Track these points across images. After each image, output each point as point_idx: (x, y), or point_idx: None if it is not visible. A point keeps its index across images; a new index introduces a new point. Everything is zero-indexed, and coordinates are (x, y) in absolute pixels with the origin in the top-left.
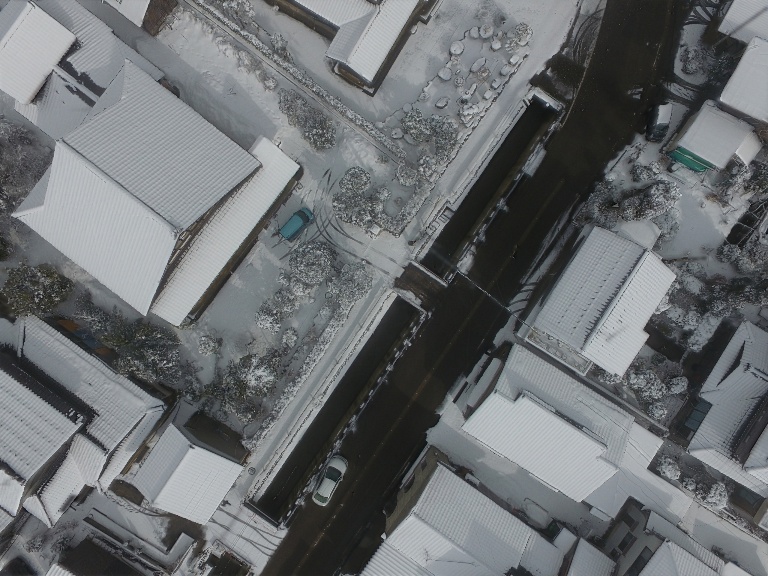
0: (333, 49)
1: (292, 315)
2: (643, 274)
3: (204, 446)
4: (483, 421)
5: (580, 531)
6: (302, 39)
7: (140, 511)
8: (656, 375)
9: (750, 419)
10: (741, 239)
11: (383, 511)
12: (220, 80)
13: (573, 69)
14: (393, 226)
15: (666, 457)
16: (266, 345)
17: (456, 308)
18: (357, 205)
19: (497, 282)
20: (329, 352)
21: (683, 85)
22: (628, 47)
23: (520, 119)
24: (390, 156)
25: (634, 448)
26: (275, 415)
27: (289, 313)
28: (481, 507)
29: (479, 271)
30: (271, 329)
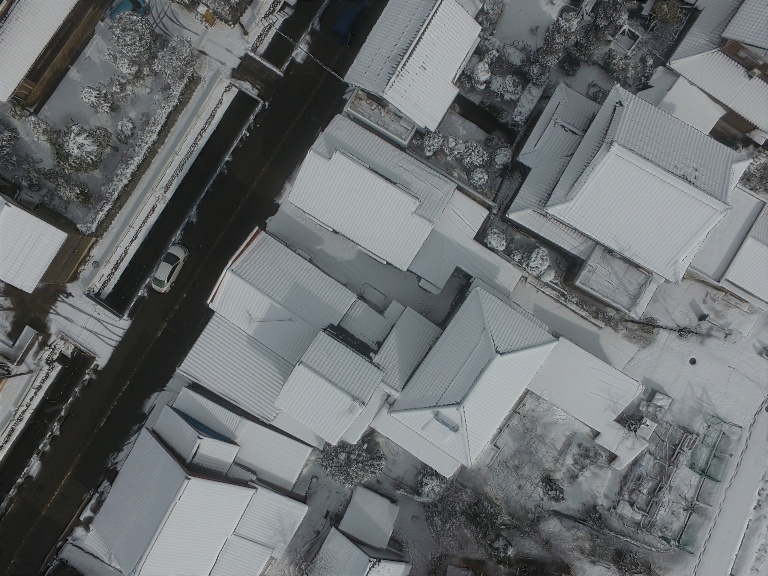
0: None
1: (126, 101)
2: (443, 18)
3: (23, 208)
4: (305, 187)
5: None
6: None
7: None
8: (479, 145)
9: None
10: None
11: None
12: None
13: None
14: (220, 6)
15: (492, 228)
16: None
17: (293, 98)
18: None
19: None
20: (169, 144)
21: None
22: None
23: None
24: None
25: (459, 217)
26: (109, 198)
27: (122, 97)
28: (305, 272)
29: None
30: (100, 108)
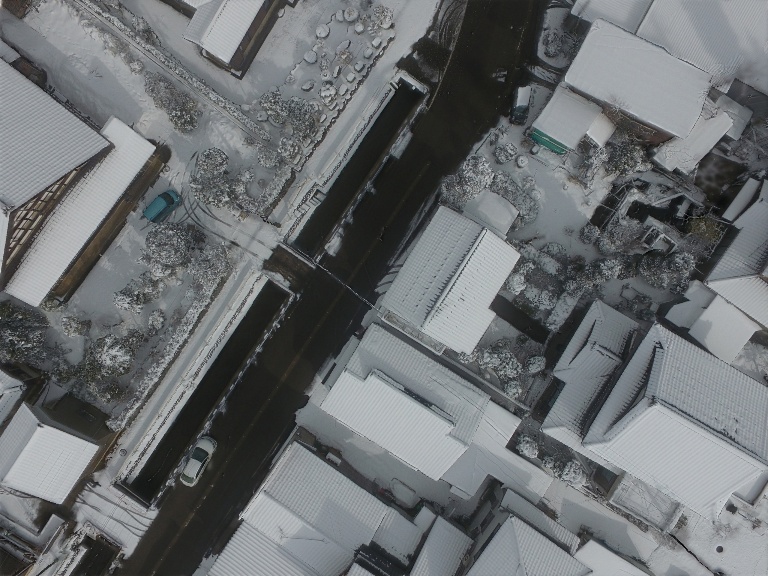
0: (189, 31)
1: (157, 297)
2: (483, 252)
3: (55, 425)
4: (338, 400)
5: (447, 510)
6: (170, 22)
7: (11, 493)
8: (513, 354)
9: (599, 397)
10: (604, 221)
11: (253, 492)
12: (86, 63)
13: (439, 52)
14: (255, 208)
15: (525, 436)
16: (135, 327)
17: (324, 290)
18: (215, 186)
19: (364, 264)
20: (199, 334)
21: (546, 68)
22: (493, 30)
23: (389, 102)
24: (256, 139)
25: (491, 427)
26: (139, 396)
27: (153, 294)
28: (336, 485)
29: (347, 253)
30: (132, 310)
